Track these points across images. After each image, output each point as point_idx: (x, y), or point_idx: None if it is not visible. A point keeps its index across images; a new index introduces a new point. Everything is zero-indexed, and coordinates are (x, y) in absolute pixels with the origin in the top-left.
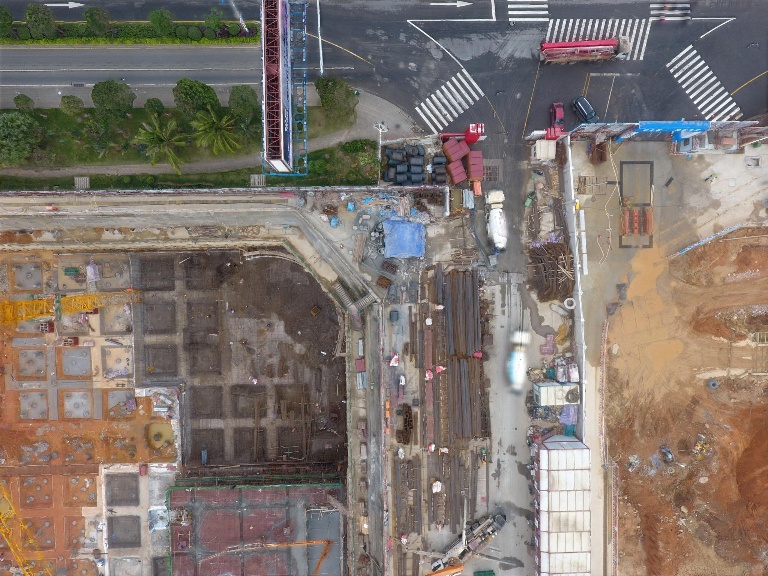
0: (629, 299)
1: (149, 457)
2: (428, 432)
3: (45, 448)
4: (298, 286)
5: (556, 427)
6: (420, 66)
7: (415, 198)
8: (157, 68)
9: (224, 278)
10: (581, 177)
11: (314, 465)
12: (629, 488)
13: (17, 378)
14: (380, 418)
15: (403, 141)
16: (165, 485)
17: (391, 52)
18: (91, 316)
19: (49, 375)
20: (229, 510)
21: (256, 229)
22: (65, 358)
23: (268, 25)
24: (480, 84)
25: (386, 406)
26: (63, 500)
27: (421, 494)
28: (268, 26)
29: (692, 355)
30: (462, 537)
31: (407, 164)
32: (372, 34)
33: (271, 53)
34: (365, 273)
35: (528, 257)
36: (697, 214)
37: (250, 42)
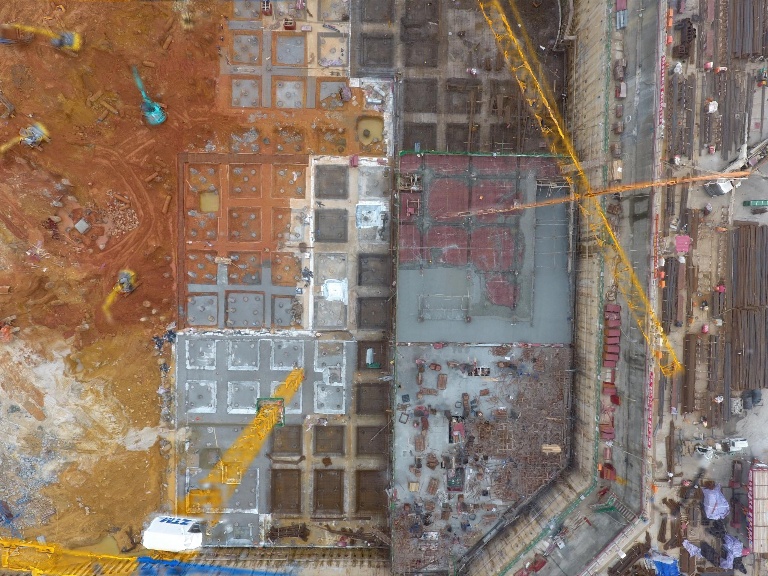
0: None
1: (359, 151)
2: (708, 47)
3: (254, 138)
4: None
5: None
6: None
7: None
8: None
9: None
10: None
11: None
12: None
13: (231, 62)
14: (658, 33)
15: None
16: (373, 181)
17: None
18: (309, 1)
19: (264, 60)
20: (459, 179)
21: None
22: (279, 46)
23: None
24: None
25: (670, 13)
26: (271, 190)
27: (694, 116)
28: None
29: None
30: (740, 154)
31: None
32: None
33: None
34: None
35: None
36: None
37: None
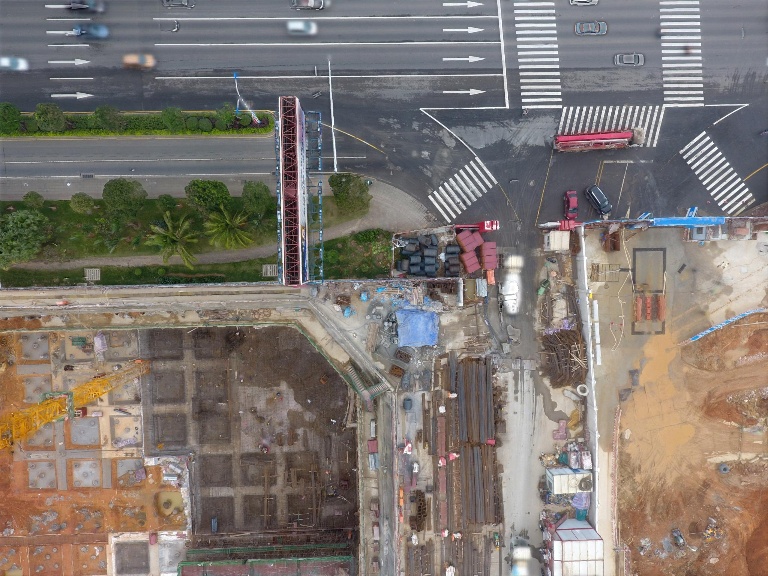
0: (641, 385)
1: (159, 525)
2: (442, 518)
3: (54, 517)
4: (307, 354)
5: (568, 511)
6: (433, 154)
7: (428, 287)
8: (167, 159)
9: (233, 347)
10: (594, 264)
11: (324, 532)
12: (640, 567)
13: (25, 448)
14: (394, 505)
15: (416, 231)
16: (175, 552)
17: (404, 141)
18: None
19: (57, 445)
20: None
21: (267, 312)
22: (73, 427)
23: (286, 150)
24: (493, 172)
25: (400, 494)
26: (73, 569)
27: None
28: (286, 151)
29: (703, 439)
30: None
31: (420, 254)
32: (384, 123)
33: (289, 178)
34: (378, 362)
35: (541, 344)
36: (709, 300)
37: (261, 132)
